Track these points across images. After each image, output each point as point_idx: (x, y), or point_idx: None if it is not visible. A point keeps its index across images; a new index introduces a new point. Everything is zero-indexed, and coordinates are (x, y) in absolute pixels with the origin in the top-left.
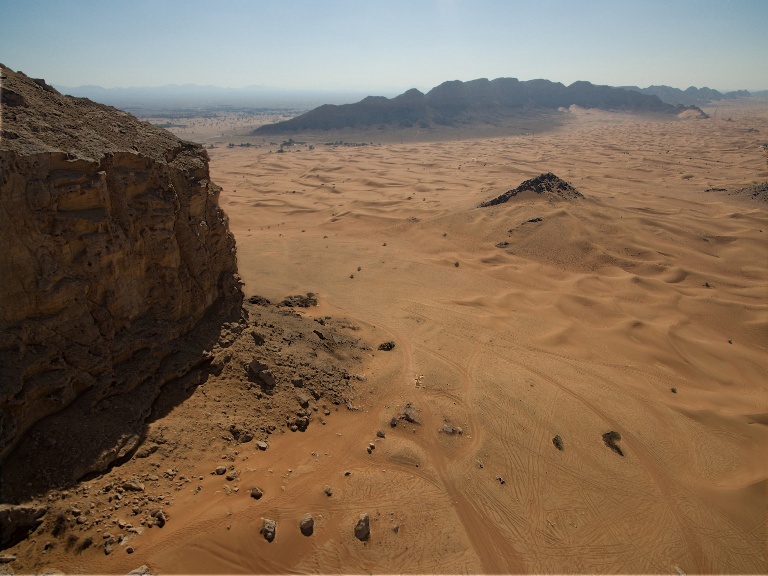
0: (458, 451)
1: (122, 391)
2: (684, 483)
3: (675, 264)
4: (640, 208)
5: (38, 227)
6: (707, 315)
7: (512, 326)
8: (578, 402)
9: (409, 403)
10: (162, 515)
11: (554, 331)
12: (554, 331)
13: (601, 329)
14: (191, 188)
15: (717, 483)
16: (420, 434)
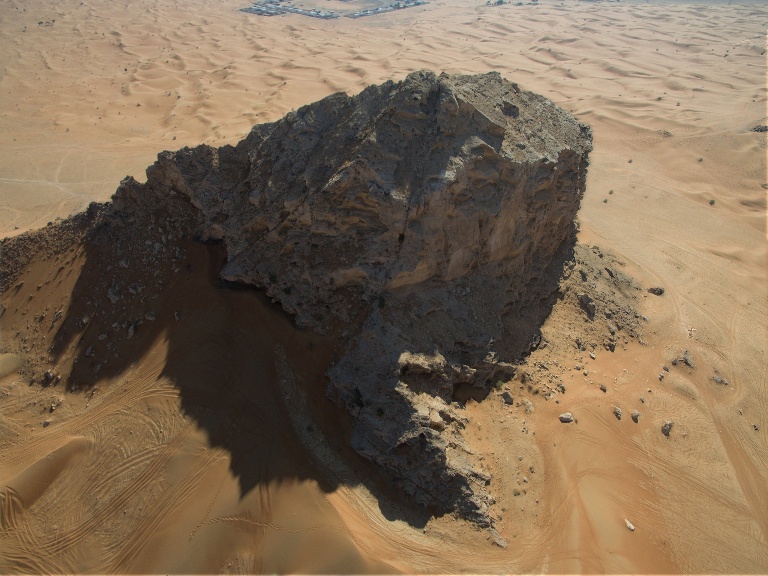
0: (724, 397)
1: (527, 305)
2: None
3: None
4: None
5: (523, 207)
6: None
7: None
8: None
9: (686, 350)
10: (564, 387)
11: None
12: None
13: None
14: (583, 167)
15: None
16: (694, 376)
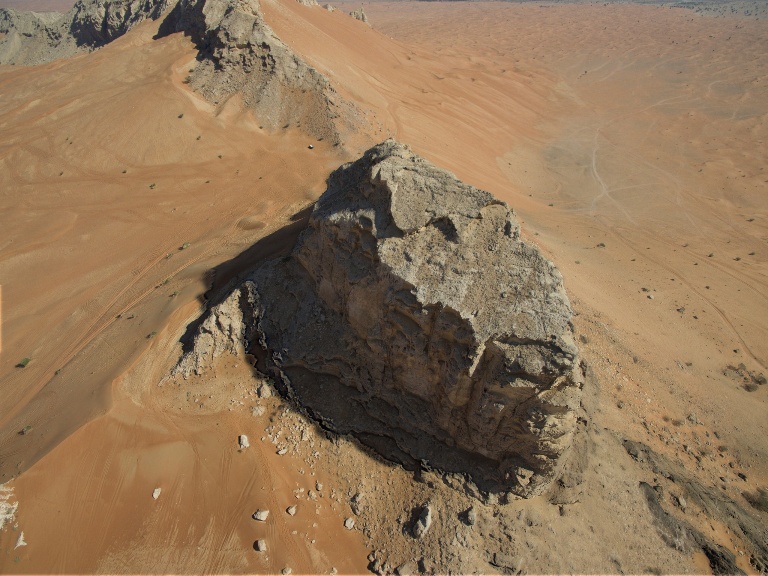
0: None
1: None
2: None
3: None
4: None
5: None
6: None
7: None
8: None
9: None
10: (280, 451)
11: None
12: None
13: None
14: None
15: None
16: None
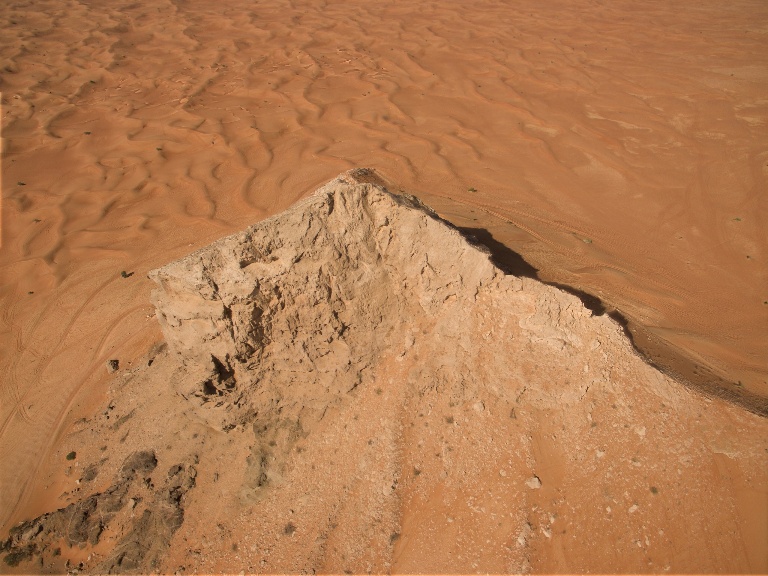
0: None
1: None
2: None
3: None
4: None
5: None
6: None
7: None
8: None
9: None
10: None
11: None
12: None
13: None
14: None
15: (124, 257)
16: None
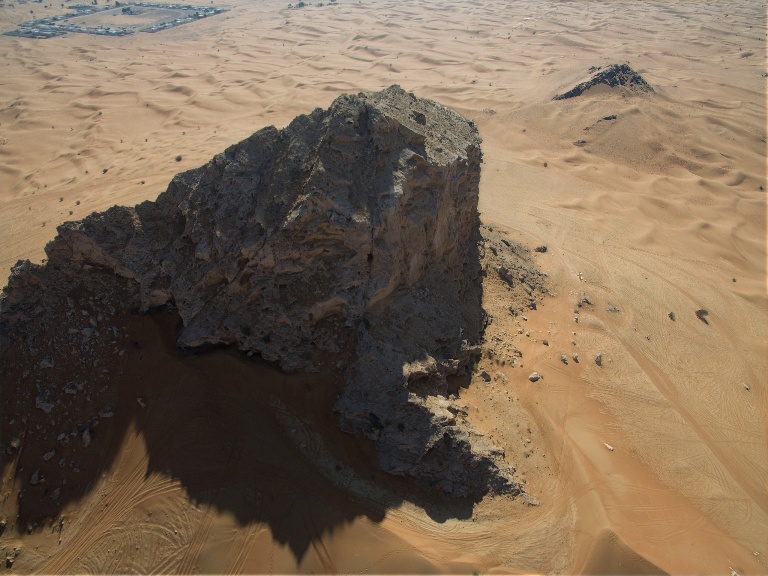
0: (621, 321)
1: None
2: (745, 341)
3: (735, 167)
4: (704, 101)
5: None
6: (759, 217)
7: (611, 228)
8: (676, 290)
9: (583, 292)
10: (521, 352)
11: (643, 232)
12: (643, 232)
13: (676, 229)
14: (479, 158)
15: (764, 341)
16: (596, 311)
